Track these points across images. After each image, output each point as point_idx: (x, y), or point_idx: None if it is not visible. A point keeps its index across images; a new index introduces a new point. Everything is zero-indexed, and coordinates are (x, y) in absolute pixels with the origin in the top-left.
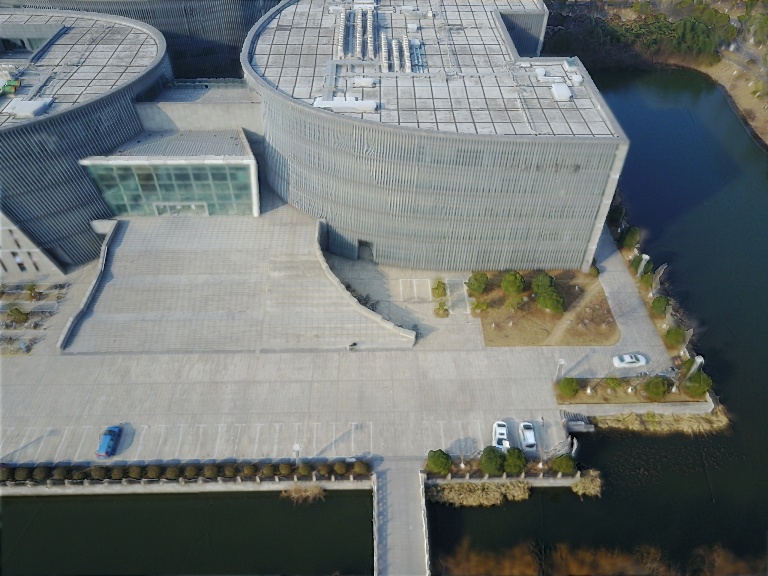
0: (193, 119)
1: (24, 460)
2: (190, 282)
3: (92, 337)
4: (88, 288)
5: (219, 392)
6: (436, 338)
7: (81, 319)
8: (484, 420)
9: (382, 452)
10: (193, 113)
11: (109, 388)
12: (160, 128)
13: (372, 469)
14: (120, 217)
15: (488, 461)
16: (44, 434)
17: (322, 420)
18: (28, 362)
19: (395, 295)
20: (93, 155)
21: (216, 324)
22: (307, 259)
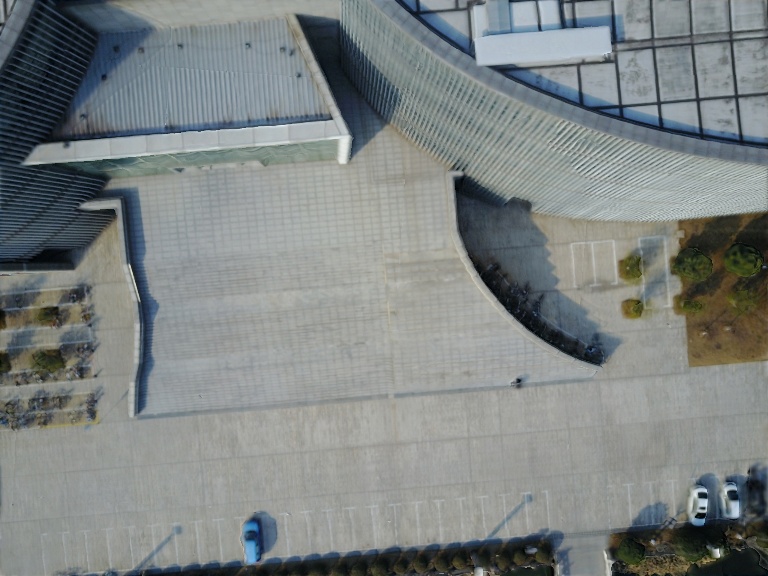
0: (194, 12)
1: (166, 564)
2: (274, 307)
3: (168, 394)
4: (134, 338)
5: (358, 462)
6: (624, 357)
7: (142, 374)
8: (679, 479)
9: (562, 528)
10: (192, 6)
11: (221, 464)
12: (130, 28)
13: (553, 552)
14: (117, 181)
15: (688, 557)
16: (173, 532)
17: (489, 492)
18: (102, 434)
19: (565, 277)
20: (40, 143)
21: (329, 367)
22: (442, 258)
